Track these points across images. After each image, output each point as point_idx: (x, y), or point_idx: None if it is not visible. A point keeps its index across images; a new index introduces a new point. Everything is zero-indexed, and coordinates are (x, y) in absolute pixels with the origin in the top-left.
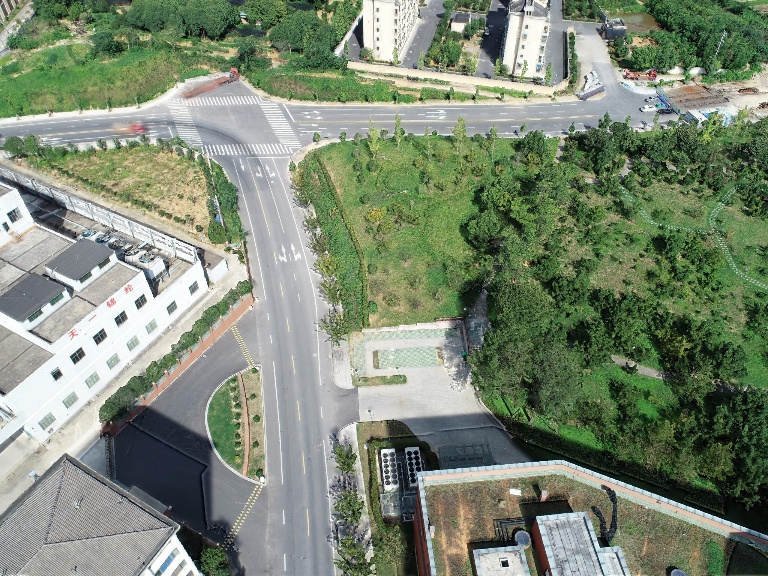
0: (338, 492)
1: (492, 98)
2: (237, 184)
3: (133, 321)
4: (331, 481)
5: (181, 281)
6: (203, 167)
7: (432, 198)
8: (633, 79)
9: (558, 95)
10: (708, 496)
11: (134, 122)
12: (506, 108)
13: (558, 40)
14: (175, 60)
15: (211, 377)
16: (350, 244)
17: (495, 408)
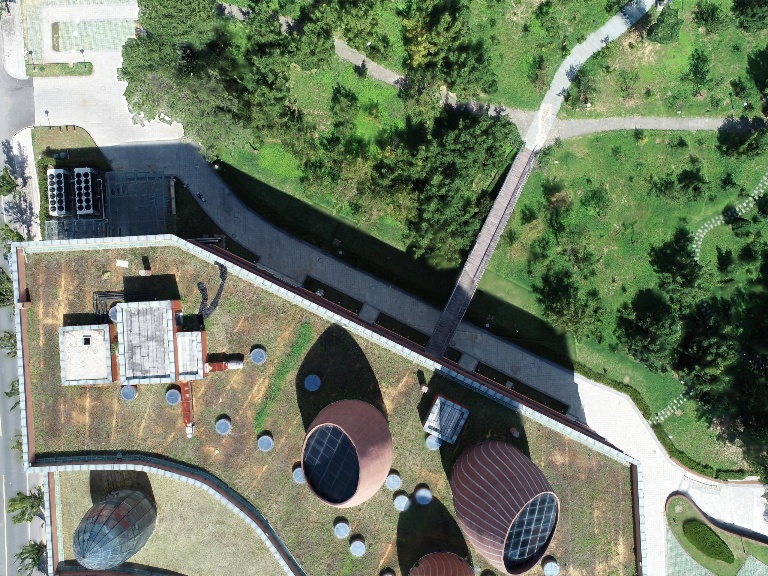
0: (13, 209)
1: None
2: None
3: None
4: (6, 196)
5: None
6: None
7: None
8: None
9: None
10: (396, 233)
11: None
12: None
13: None
14: None
15: None
16: None
17: None
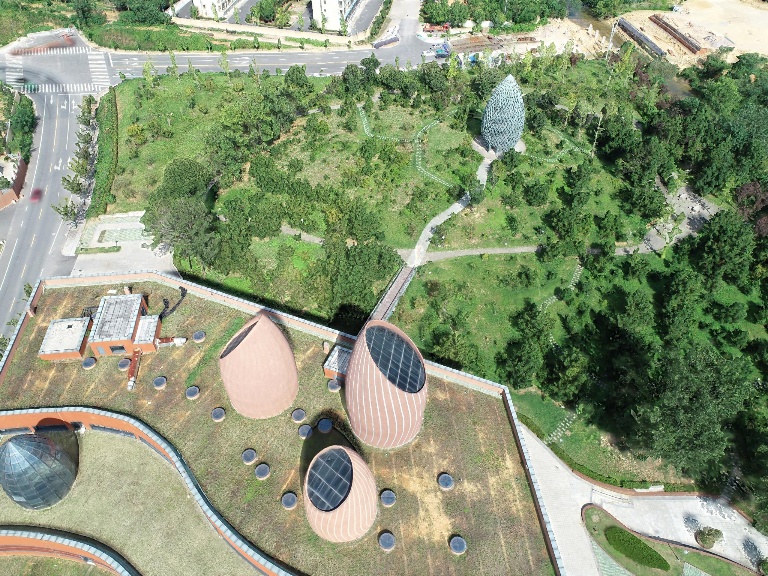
0: None
1: (296, 47)
2: (41, 114)
3: None
4: None
5: None
6: (8, 98)
7: (193, 119)
8: (430, 31)
9: (356, 44)
10: (318, 320)
11: None
12: (305, 55)
13: (379, 1)
14: (21, 18)
15: None
16: (111, 154)
17: (179, 266)
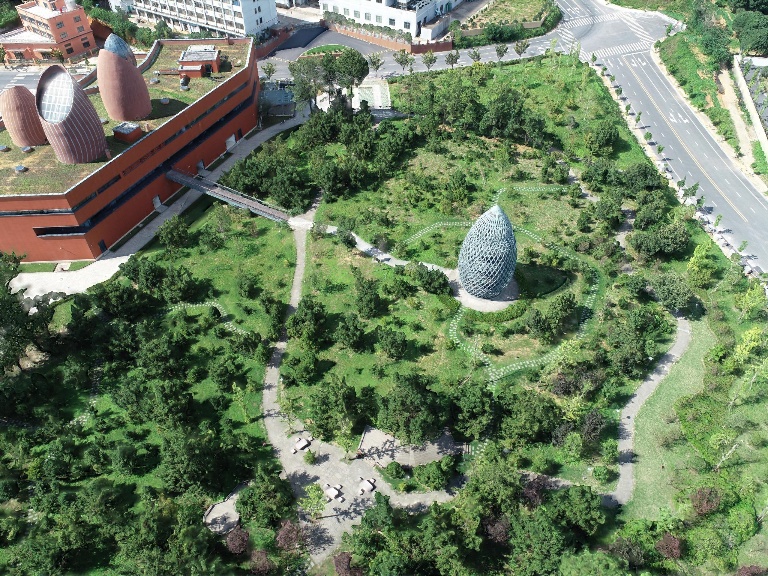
0: None
1: None
2: None
3: (372, 5)
4: None
5: (402, 13)
6: None
7: None
8: None
9: None
10: None
11: (587, 5)
12: (720, 158)
13: None
14: (678, 1)
15: (355, 45)
16: None
17: None
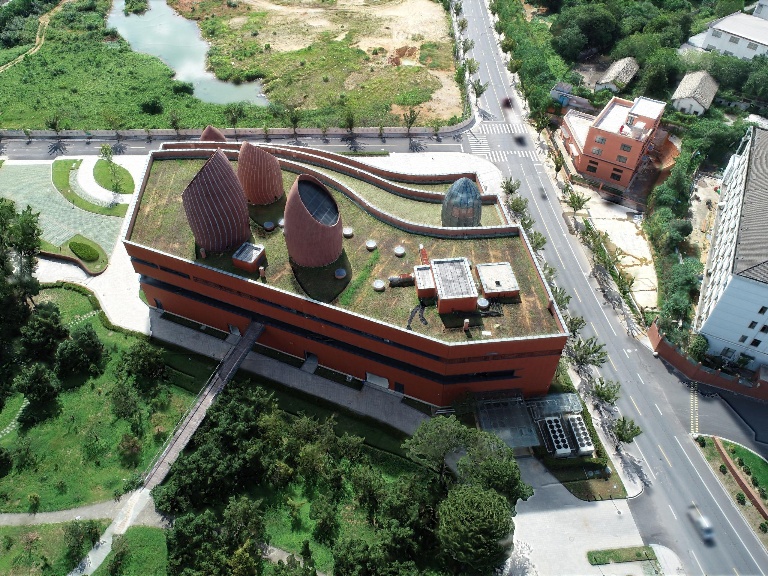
0: None
1: None
2: None
3: None
4: None
5: None
6: None
7: None
8: None
9: None
10: None
11: None
12: None
13: None
14: None
15: None
16: None
17: None
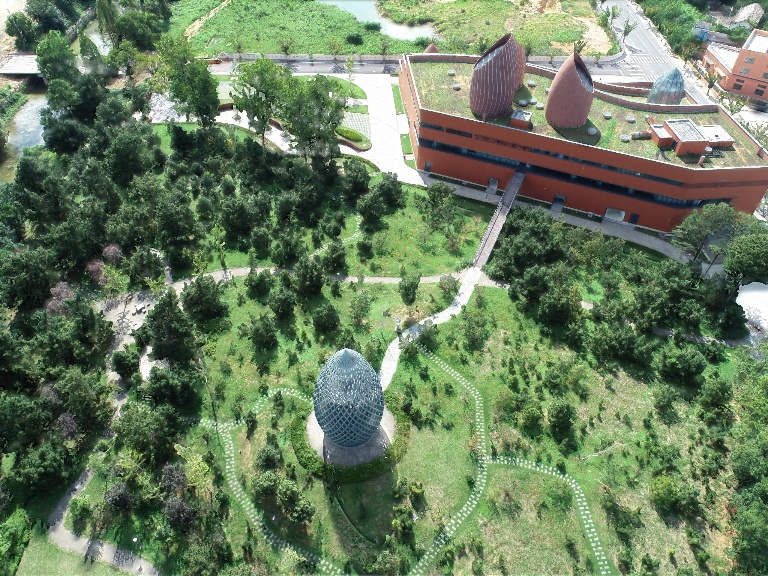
0: None
1: None
2: None
3: None
4: None
5: None
6: None
7: None
8: None
9: None
10: None
11: None
12: None
13: None
14: None
15: None
16: None
17: None
